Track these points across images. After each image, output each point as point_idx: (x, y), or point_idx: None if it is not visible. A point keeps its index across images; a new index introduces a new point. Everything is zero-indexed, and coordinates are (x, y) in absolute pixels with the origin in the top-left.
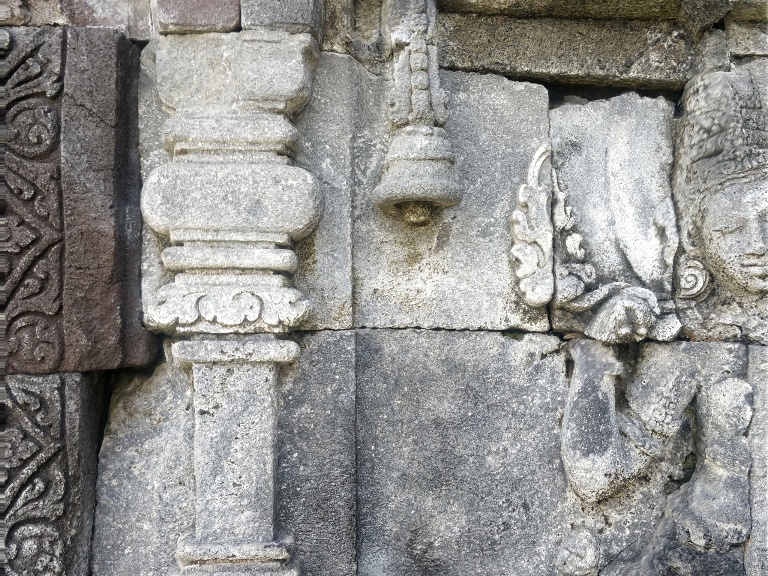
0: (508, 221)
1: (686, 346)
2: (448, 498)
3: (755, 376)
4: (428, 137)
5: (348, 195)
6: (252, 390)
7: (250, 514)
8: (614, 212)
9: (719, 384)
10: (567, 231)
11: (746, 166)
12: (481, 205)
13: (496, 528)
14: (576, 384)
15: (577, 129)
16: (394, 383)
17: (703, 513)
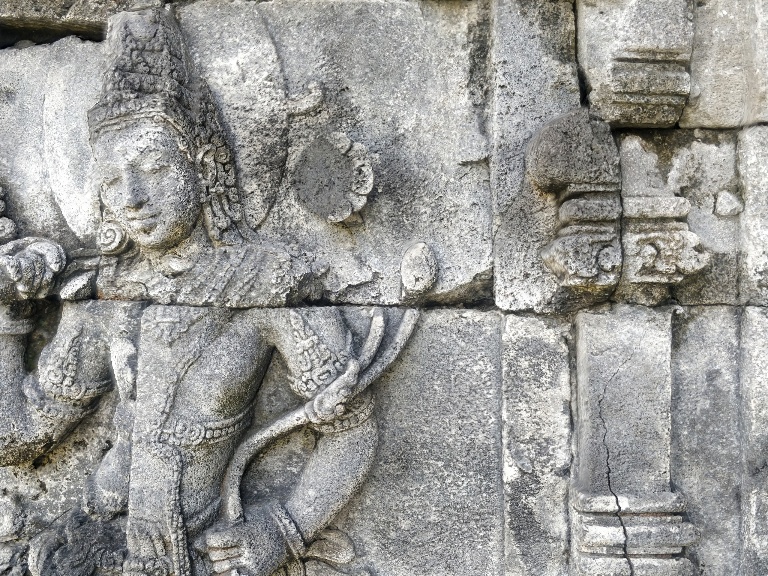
0: None
1: (91, 305)
2: None
3: (141, 336)
4: None
5: None
6: None
7: None
8: (47, 163)
9: (113, 345)
10: None
11: (114, 112)
12: None
13: None
14: None
15: (12, 75)
16: None
17: (98, 480)
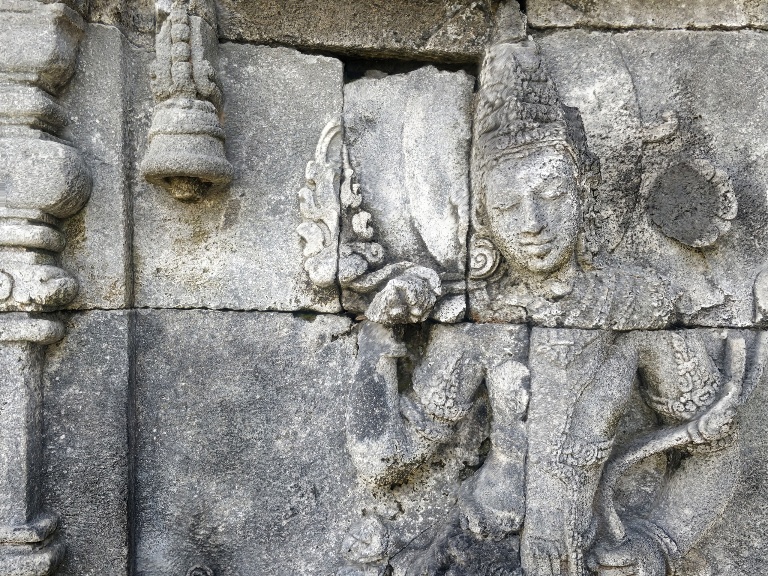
0: (298, 199)
1: (470, 328)
2: (233, 482)
3: (533, 359)
4: (186, 110)
5: (120, 171)
6: (4, 370)
7: (1, 496)
8: (408, 190)
9: (499, 367)
10: (355, 209)
11: (519, 141)
12: (271, 182)
13: (283, 514)
14: (355, 366)
15: (372, 104)
16: (178, 365)
17: (482, 500)
